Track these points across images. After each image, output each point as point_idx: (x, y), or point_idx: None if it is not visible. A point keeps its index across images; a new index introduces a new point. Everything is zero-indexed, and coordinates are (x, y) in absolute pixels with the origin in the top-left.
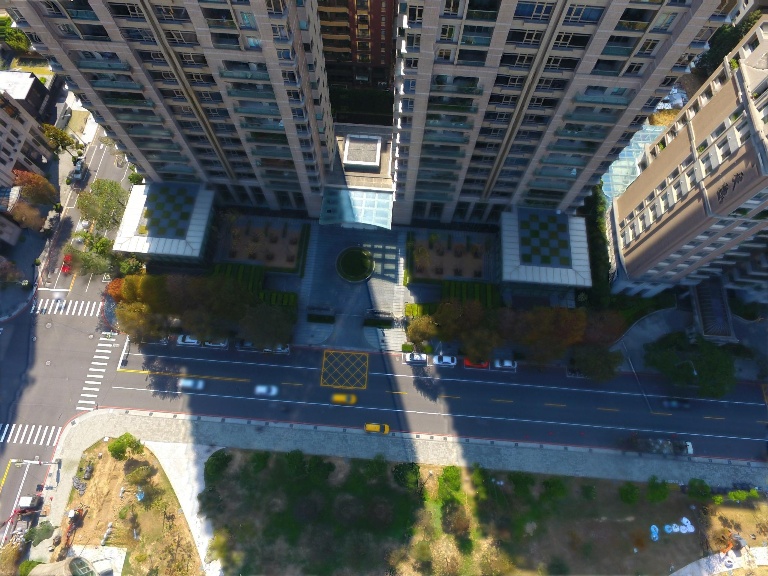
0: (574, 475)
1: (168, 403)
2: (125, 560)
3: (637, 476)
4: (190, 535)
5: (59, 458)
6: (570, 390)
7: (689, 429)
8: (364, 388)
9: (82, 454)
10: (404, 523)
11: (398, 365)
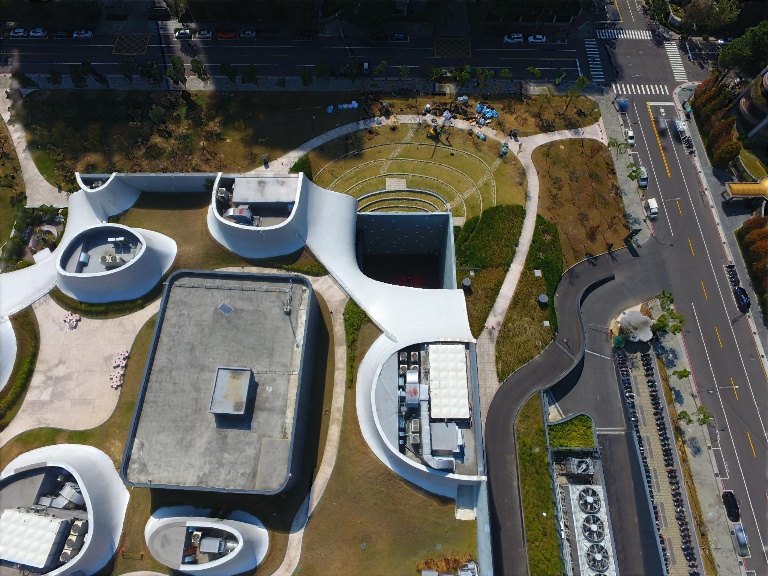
0: (286, 90)
1: (1, 69)
2: None
3: (331, 89)
4: (8, 132)
5: None
6: (293, 47)
7: (375, 63)
8: (144, 54)
9: None
10: None
11: (170, 40)
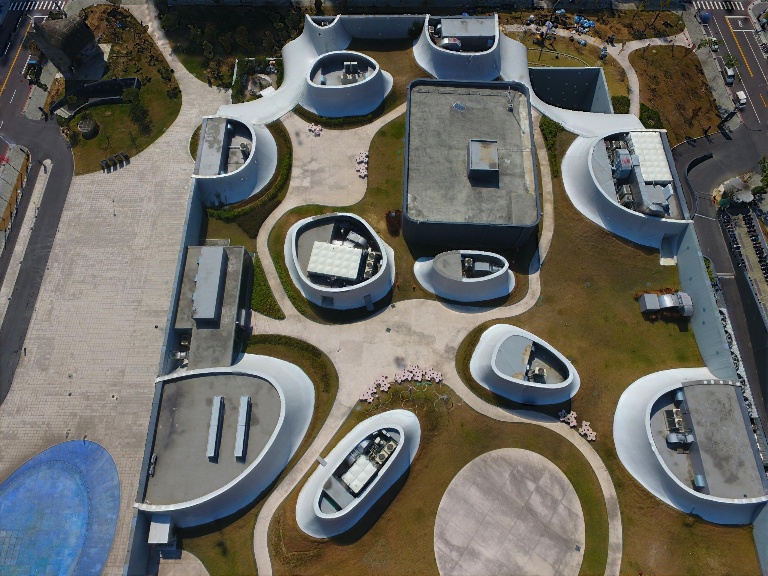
0: (399, 6)
1: None
2: (111, 49)
3: (439, 4)
4: (152, 40)
5: (65, 12)
6: None
7: None
8: None
9: (80, 11)
10: (287, 26)
11: None
